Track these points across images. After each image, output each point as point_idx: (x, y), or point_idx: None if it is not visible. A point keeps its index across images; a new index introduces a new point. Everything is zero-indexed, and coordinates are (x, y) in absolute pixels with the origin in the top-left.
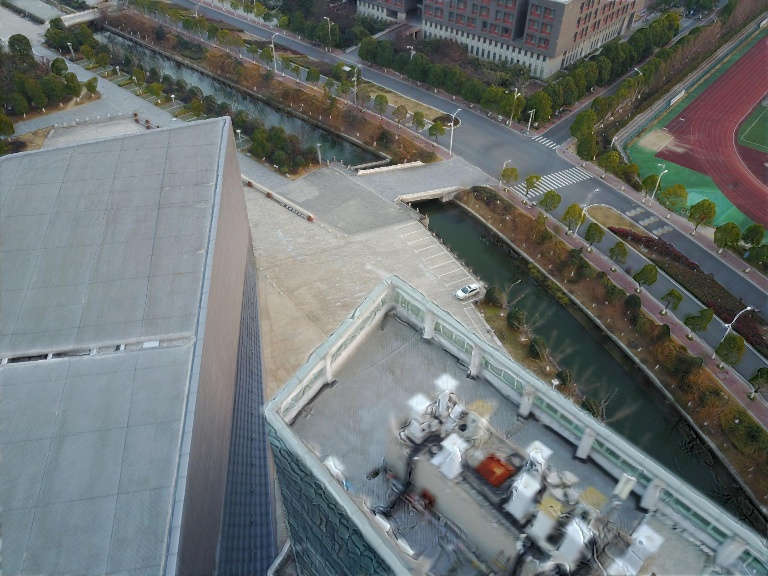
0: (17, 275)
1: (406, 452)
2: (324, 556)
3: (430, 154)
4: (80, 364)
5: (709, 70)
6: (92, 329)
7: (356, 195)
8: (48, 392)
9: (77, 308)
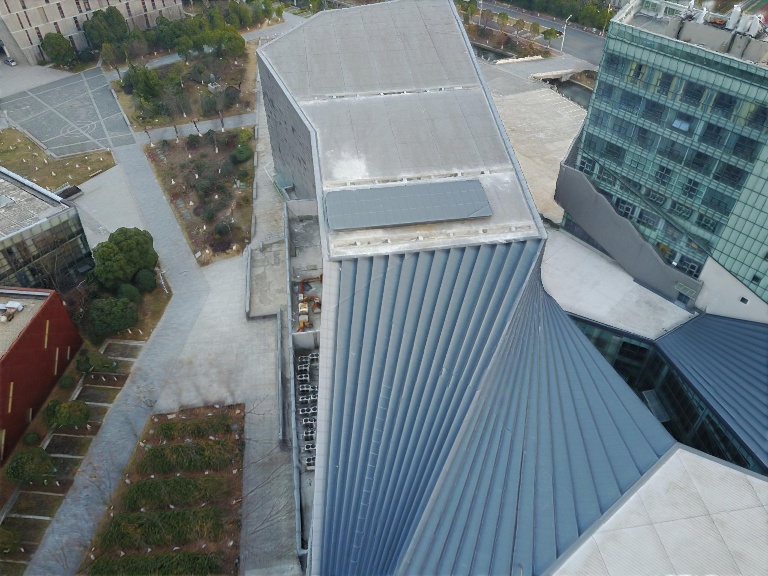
0: (365, 62)
1: (679, 20)
2: (622, 101)
3: (546, 52)
4: (424, 95)
5: (756, 1)
6: (422, 82)
7: (499, 75)
8: (414, 104)
9: (408, 74)
